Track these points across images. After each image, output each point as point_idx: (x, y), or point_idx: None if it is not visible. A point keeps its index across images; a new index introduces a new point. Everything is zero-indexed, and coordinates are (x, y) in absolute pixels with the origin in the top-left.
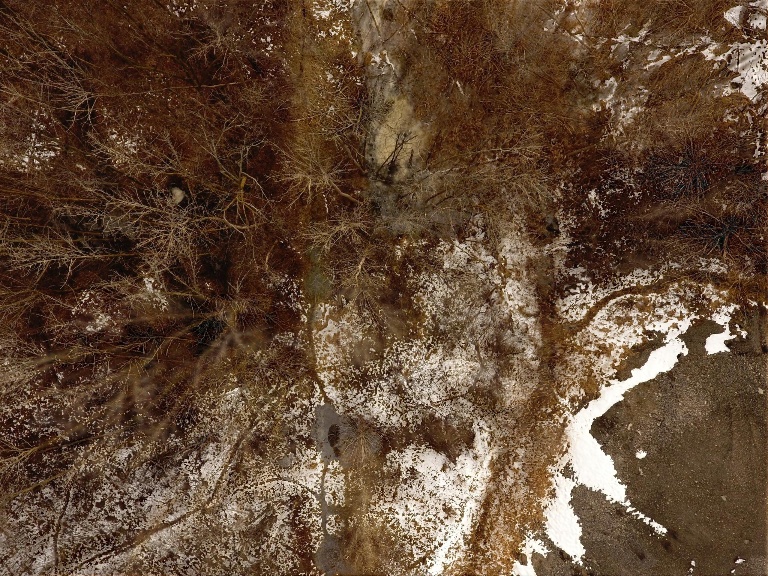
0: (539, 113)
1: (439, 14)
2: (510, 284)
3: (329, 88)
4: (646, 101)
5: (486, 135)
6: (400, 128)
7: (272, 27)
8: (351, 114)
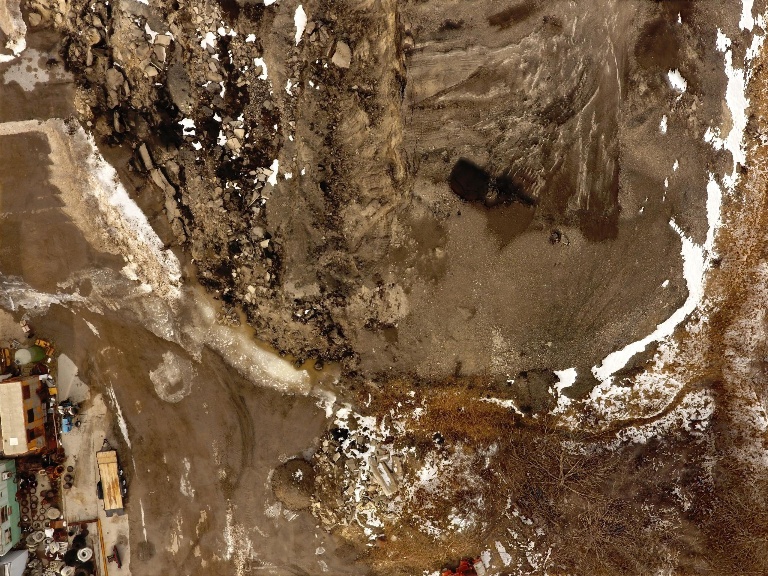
0: (734, 572)
1: None
2: (762, 426)
3: None
4: None
5: None
6: None
7: None
8: None
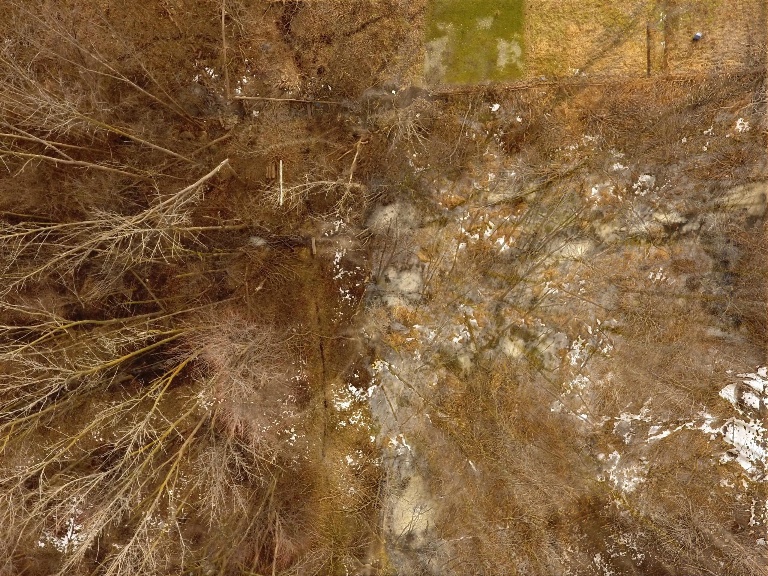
0: (547, 484)
1: (452, 401)
2: None
3: (349, 470)
4: (647, 472)
5: (497, 507)
6: (416, 502)
7: (295, 419)
8: (370, 492)
